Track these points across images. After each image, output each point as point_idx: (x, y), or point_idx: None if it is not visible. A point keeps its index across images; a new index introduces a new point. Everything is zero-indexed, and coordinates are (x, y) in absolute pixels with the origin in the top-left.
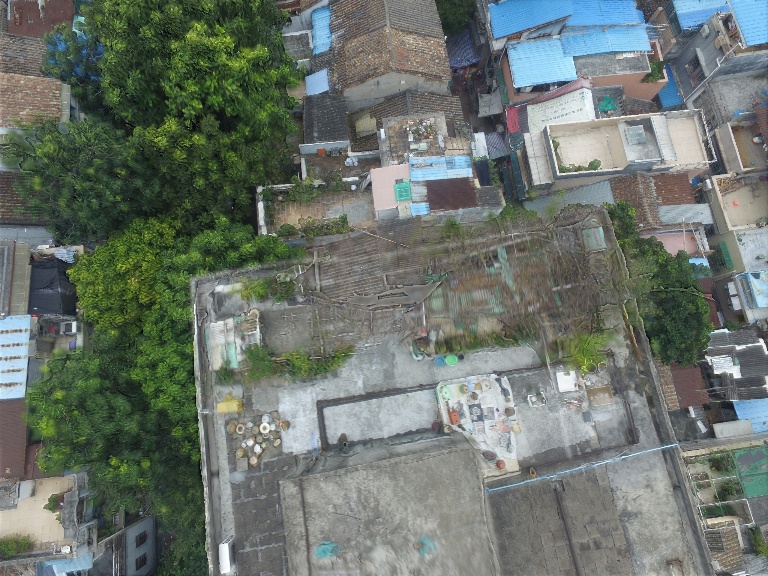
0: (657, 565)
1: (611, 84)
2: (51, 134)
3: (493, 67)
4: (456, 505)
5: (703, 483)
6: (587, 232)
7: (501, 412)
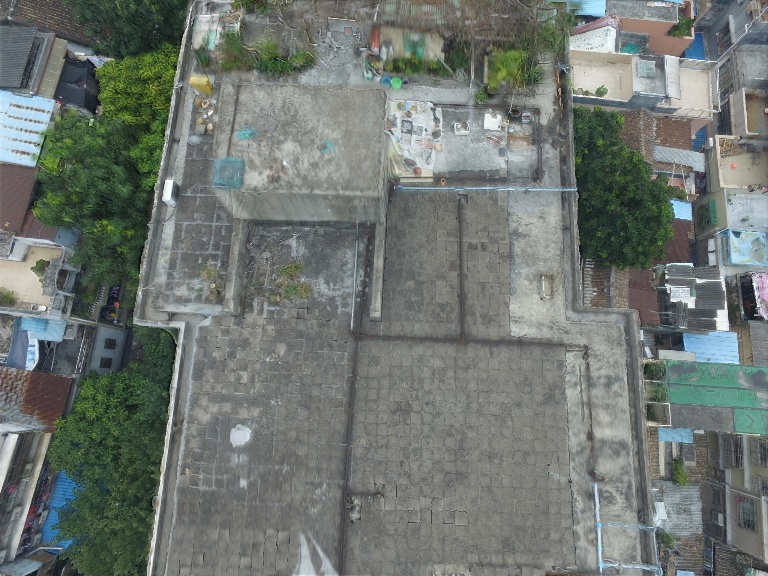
0: (532, 277)
1: (638, 31)
2: None
3: None
4: (360, 126)
5: None
6: (542, 12)
7: (429, 133)
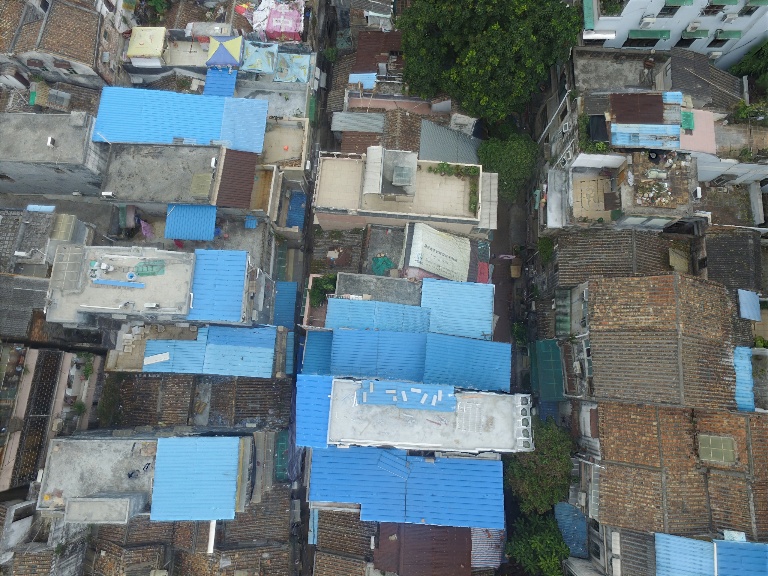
0: None
1: None
2: None
3: None
4: None
5: None
6: None
7: None
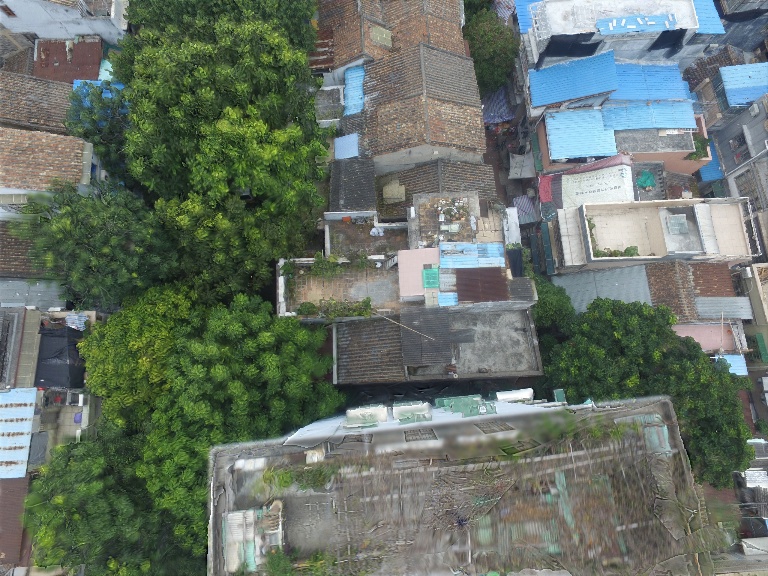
0: None
1: (652, 160)
2: (70, 205)
3: (527, 128)
4: None
5: None
6: (649, 430)
7: None
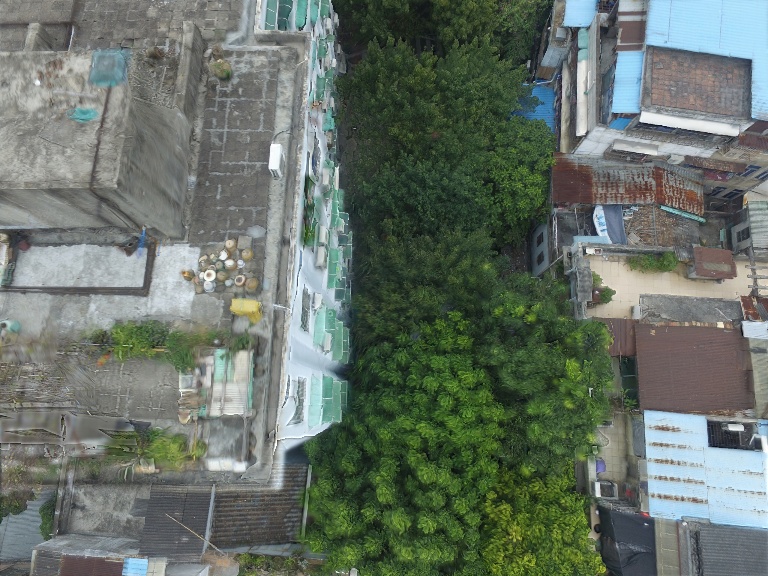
0: None
1: None
2: None
3: None
4: None
5: None
6: None
7: None
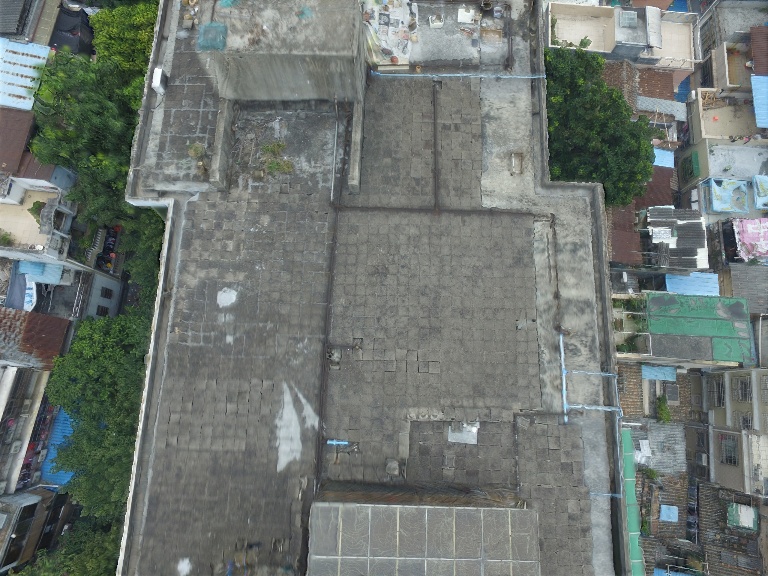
0: (503, 156)
1: None
2: None
3: None
4: None
5: (617, 325)
6: None
7: (405, 25)
